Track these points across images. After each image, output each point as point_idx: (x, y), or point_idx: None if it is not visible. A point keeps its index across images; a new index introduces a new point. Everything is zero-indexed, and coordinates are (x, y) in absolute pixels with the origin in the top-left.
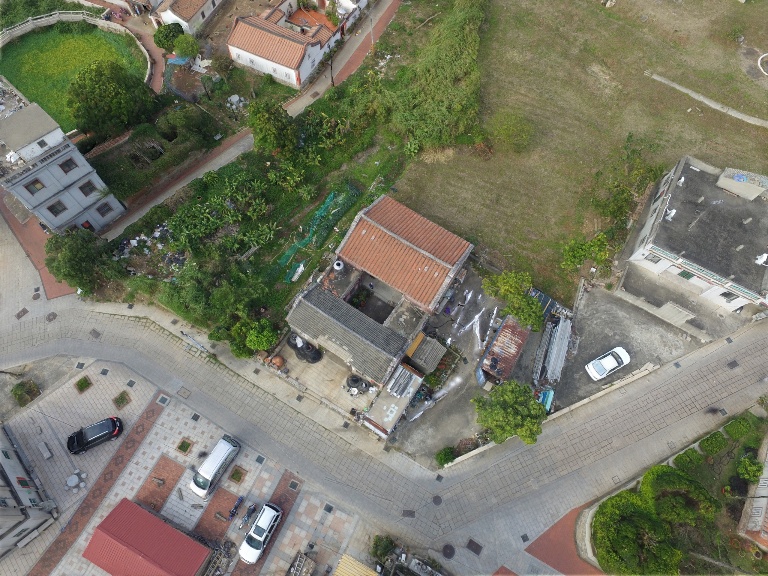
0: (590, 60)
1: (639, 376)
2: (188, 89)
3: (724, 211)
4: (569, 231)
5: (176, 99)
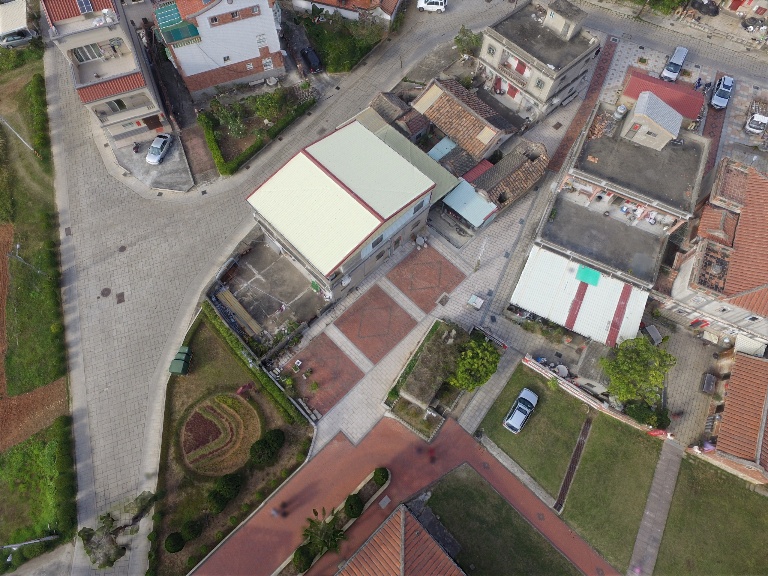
0: None
1: None
2: None
3: None
4: None
5: None
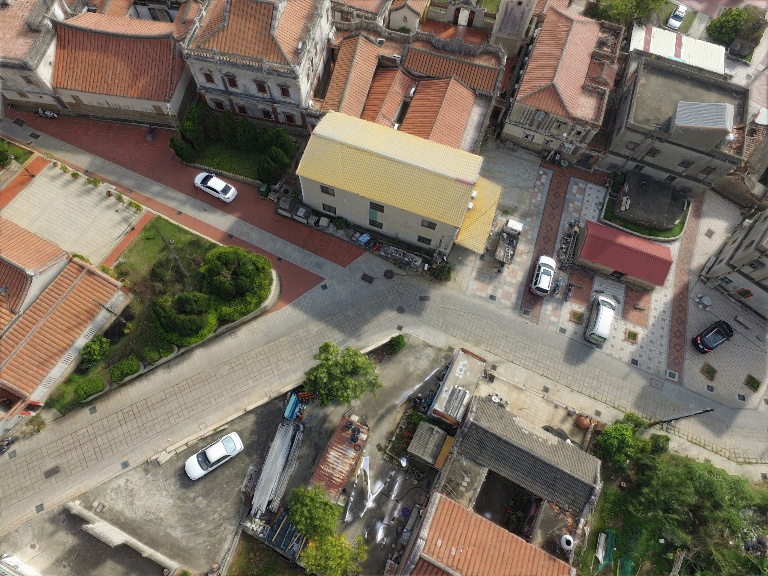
0: None
1: (180, 443)
2: None
3: None
4: None
5: None
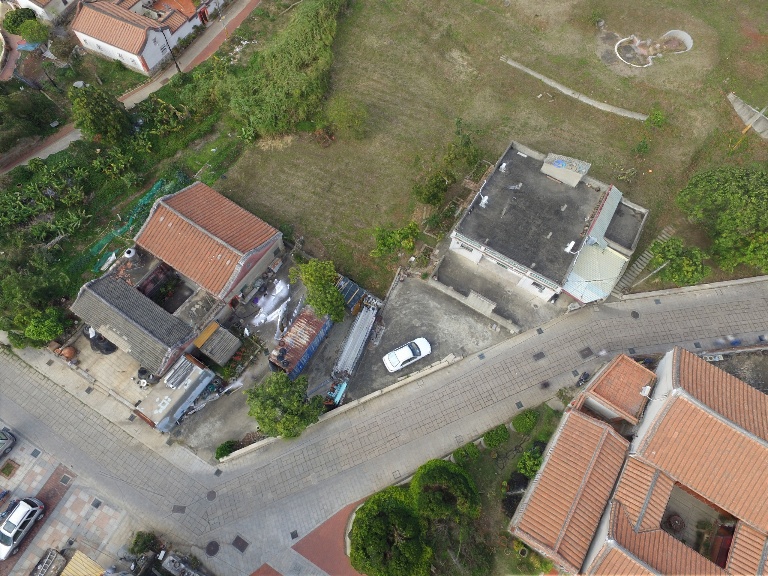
0: (450, 46)
1: (437, 368)
2: (35, 76)
3: (543, 198)
4: (398, 219)
5: (22, 86)
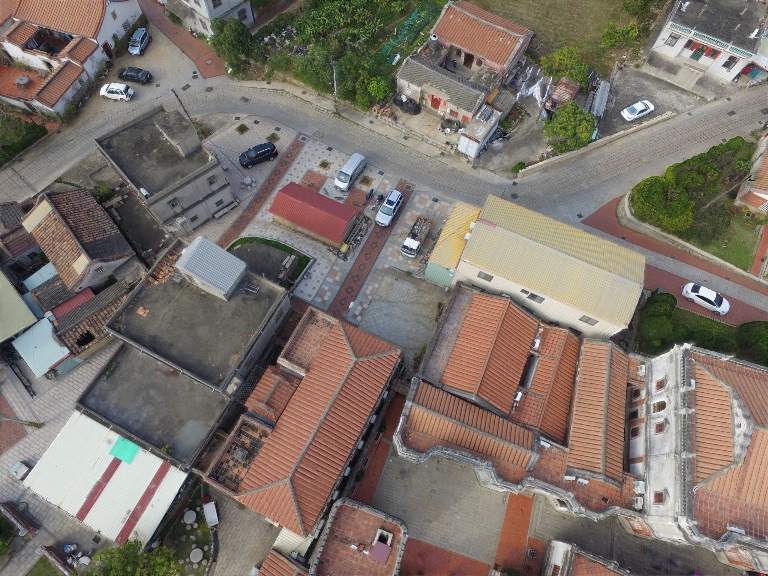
0: None
1: (661, 118)
2: None
3: (726, 7)
4: None
5: None
